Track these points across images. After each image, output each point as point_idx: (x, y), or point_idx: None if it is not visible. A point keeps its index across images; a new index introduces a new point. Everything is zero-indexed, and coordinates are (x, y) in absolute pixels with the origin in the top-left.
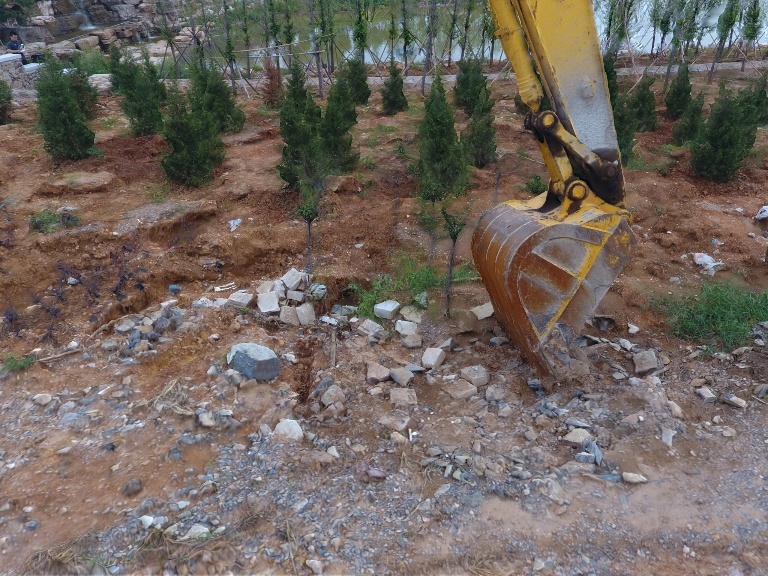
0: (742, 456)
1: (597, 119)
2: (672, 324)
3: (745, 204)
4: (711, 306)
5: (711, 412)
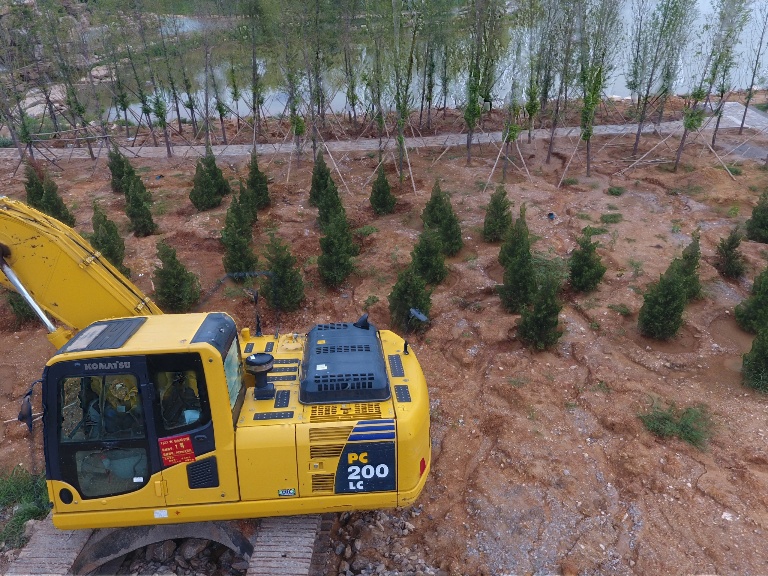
0: None
1: None
2: None
3: None
4: None
5: None
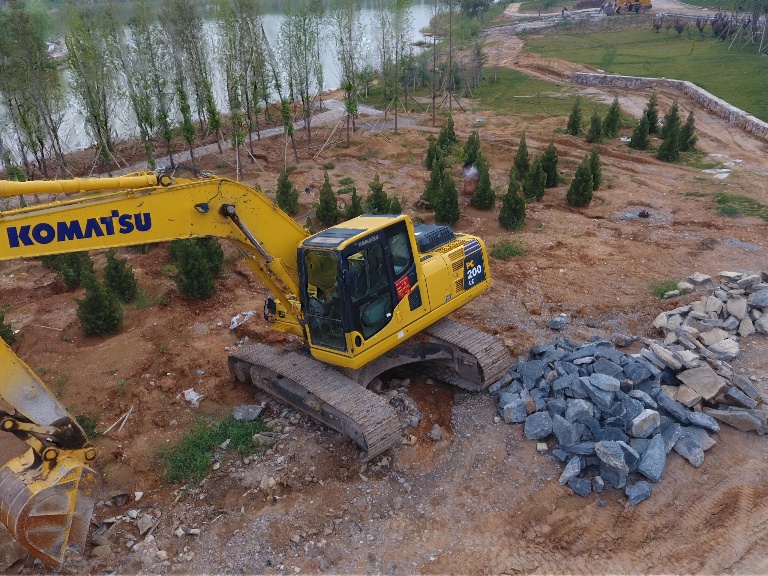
0: (197, 570)
1: (45, 406)
2: (165, 477)
3: (224, 317)
4: (187, 451)
5: (183, 545)
